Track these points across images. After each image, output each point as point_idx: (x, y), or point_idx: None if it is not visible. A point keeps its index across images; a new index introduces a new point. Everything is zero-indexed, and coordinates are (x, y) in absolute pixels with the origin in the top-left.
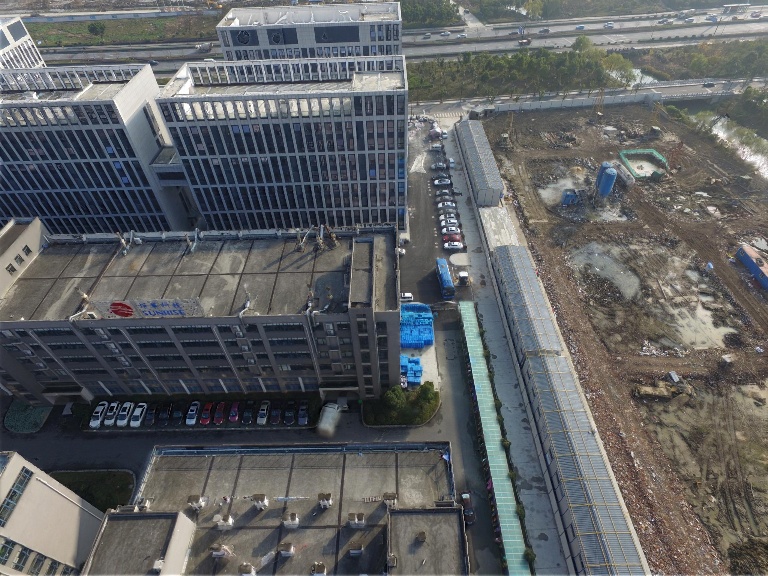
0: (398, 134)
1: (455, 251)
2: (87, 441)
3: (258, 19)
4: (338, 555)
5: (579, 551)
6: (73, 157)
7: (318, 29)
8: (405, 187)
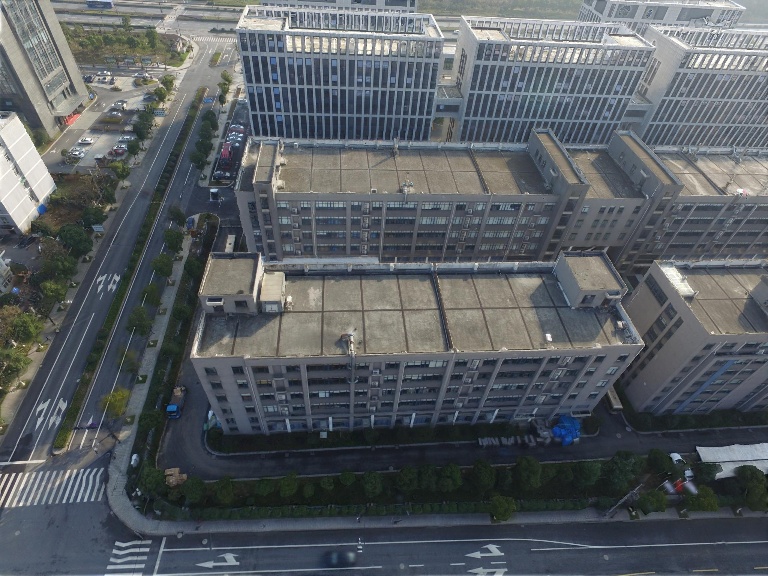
0: None
1: None
2: None
3: None
4: None
5: None
6: (586, 92)
7: (684, 9)
8: None
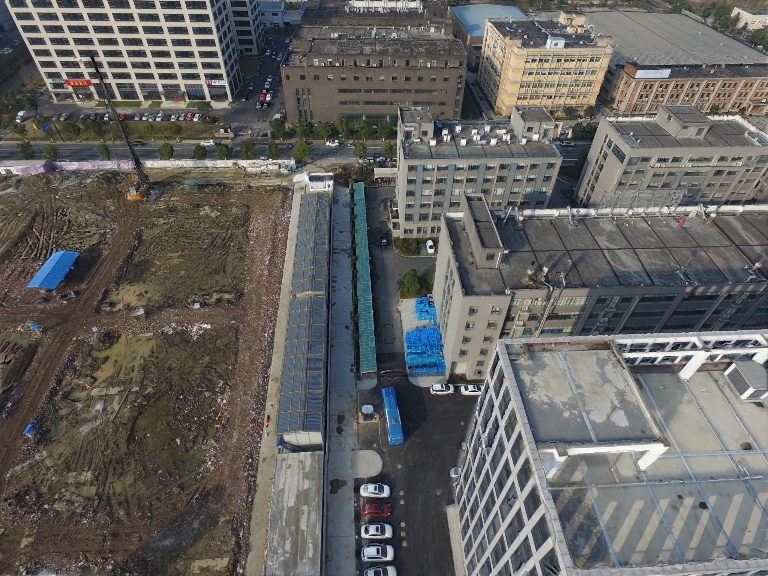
0: None
1: (373, 482)
2: None
3: None
4: (452, 135)
5: None
6: None
7: None
8: None
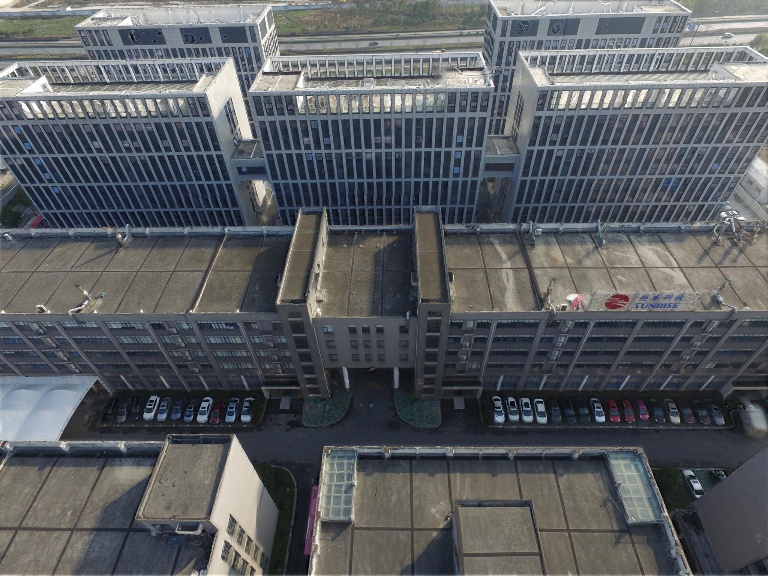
0: (766, 127)
1: None
2: (500, 437)
3: (515, 10)
4: None
5: None
6: (417, 146)
7: (603, 20)
8: (738, 182)
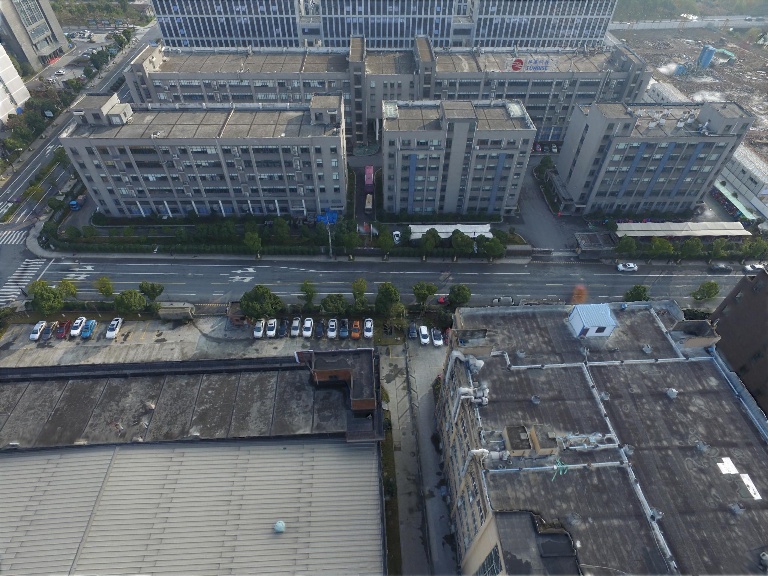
0: (611, 4)
1: None
2: None
3: None
4: None
5: (749, 176)
6: (414, 13)
7: None
8: None
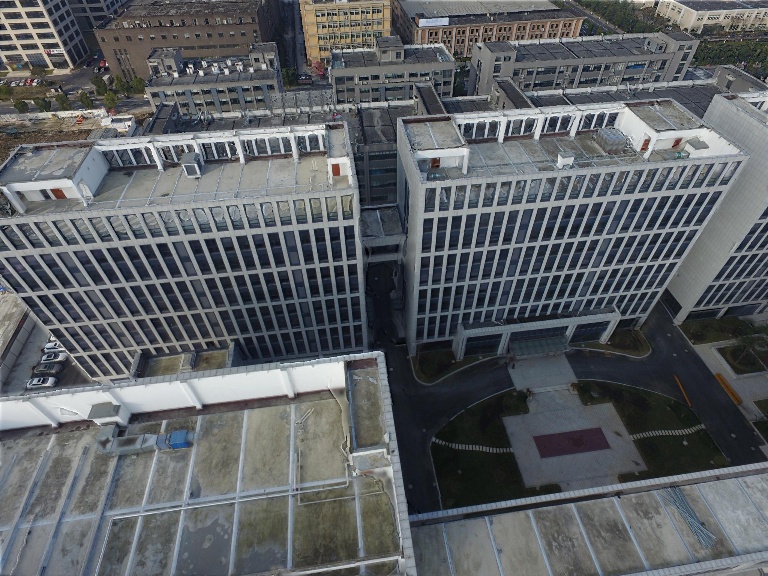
0: None
1: None
2: None
3: (303, 575)
4: None
5: None
6: None
7: None
8: None
